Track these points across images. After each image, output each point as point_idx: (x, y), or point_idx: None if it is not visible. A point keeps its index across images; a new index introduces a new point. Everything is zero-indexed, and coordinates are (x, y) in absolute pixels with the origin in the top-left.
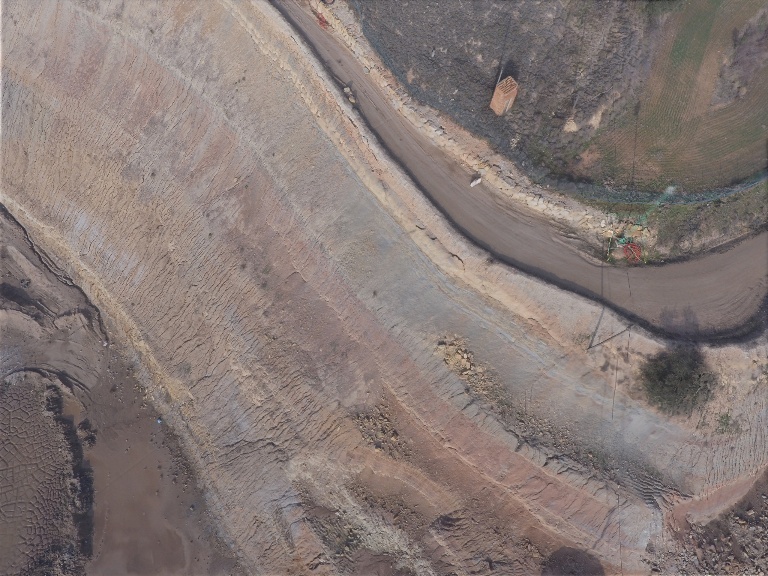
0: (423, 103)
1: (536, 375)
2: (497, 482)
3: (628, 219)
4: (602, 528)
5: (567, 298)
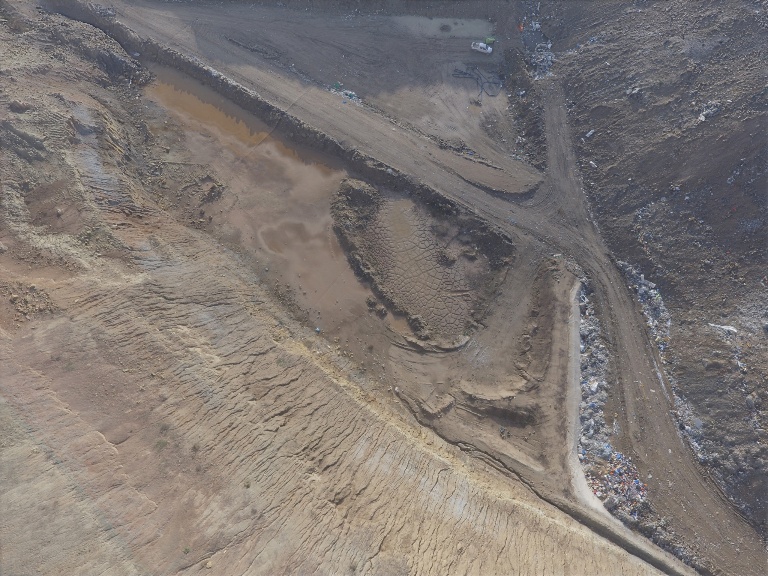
0: None
1: None
2: None
3: None
4: None
5: None
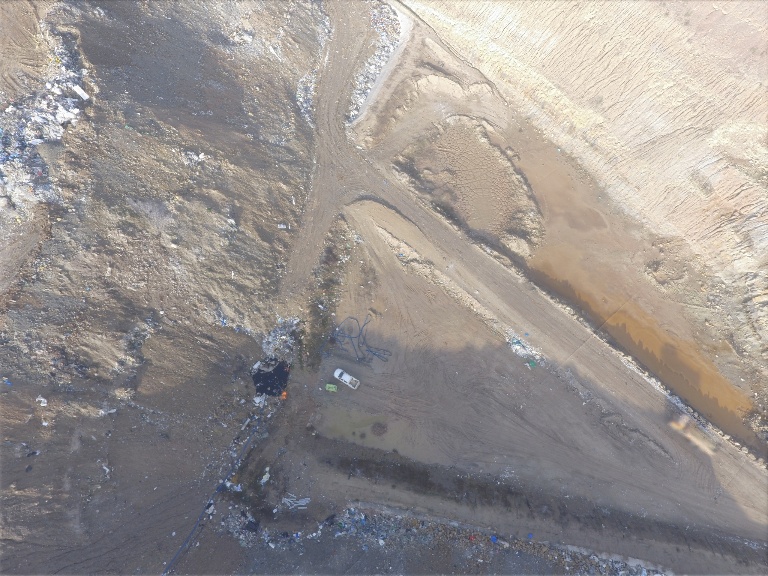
0: None
1: None
2: None
3: None
4: None
5: None
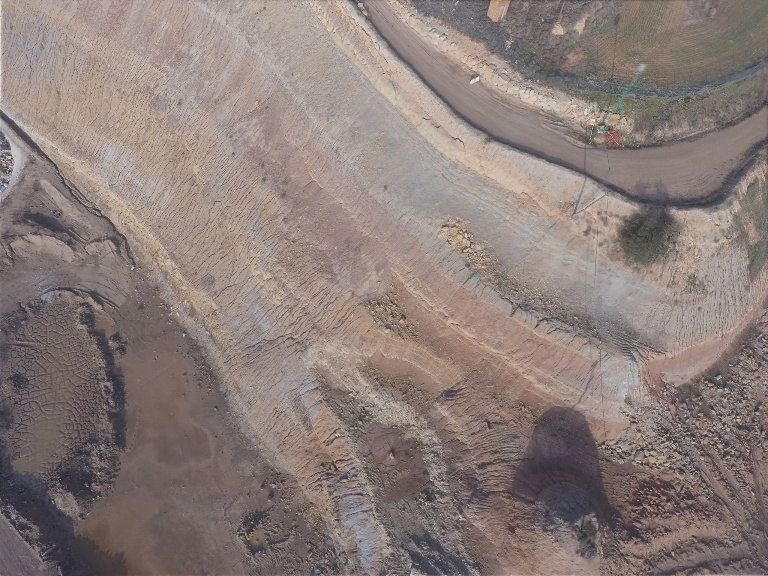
0: (428, 14)
1: (528, 249)
2: (494, 350)
3: (608, 109)
4: (586, 381)
5: (554, 170)
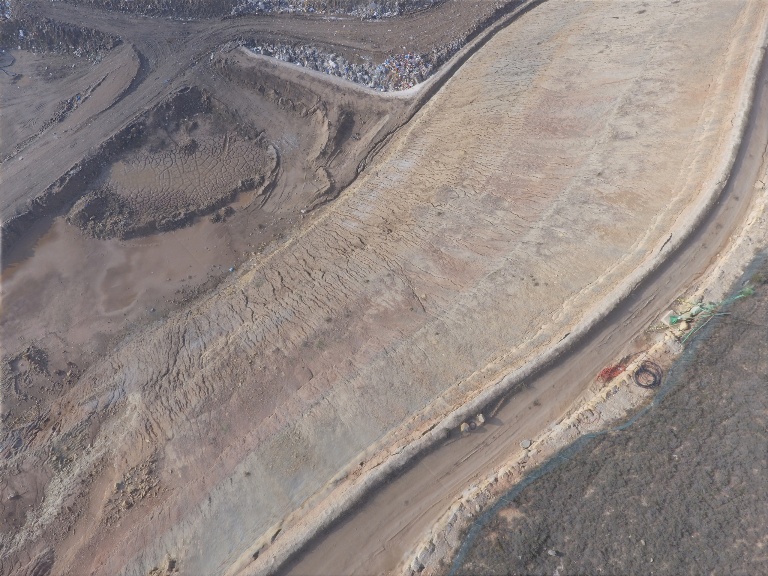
0: (464, 536)
1: None
2: None
3: None
4: None
5: None
